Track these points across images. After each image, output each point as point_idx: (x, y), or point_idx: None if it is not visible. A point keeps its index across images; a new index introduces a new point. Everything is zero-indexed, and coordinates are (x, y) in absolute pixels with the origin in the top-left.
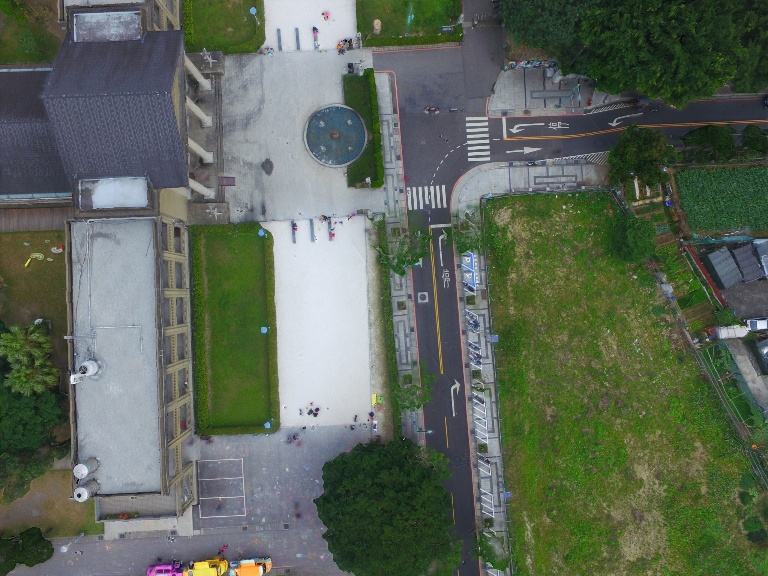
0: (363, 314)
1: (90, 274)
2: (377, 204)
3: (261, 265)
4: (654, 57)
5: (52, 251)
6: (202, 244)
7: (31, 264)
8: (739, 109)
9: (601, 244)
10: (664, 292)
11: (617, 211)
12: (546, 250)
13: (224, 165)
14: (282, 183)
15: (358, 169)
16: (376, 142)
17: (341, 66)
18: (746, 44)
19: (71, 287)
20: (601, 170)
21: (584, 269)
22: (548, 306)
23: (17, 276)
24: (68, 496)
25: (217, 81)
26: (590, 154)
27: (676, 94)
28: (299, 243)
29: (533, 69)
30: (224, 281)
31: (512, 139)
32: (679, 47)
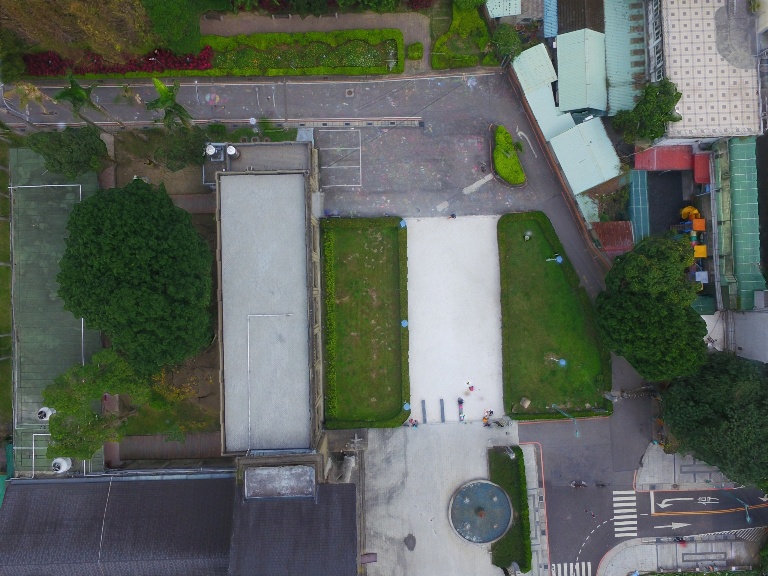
0: None
1: None
2: None
3: None
4: None
5: None
6: None
7: None
8: None
9: None
10: None
11: None
12: None
13: (366, 540)
14: (425, 559)
15: (504, 551)
16: (525, 529)
17: (486, 438)
18: None
19: None
20: (751, 546)
21: None
22: None
23: None
24: None
25: (361, 456)
26: (740, 530)
27: None
28: None
29: None
30: None
31: (660, 514)
32: None
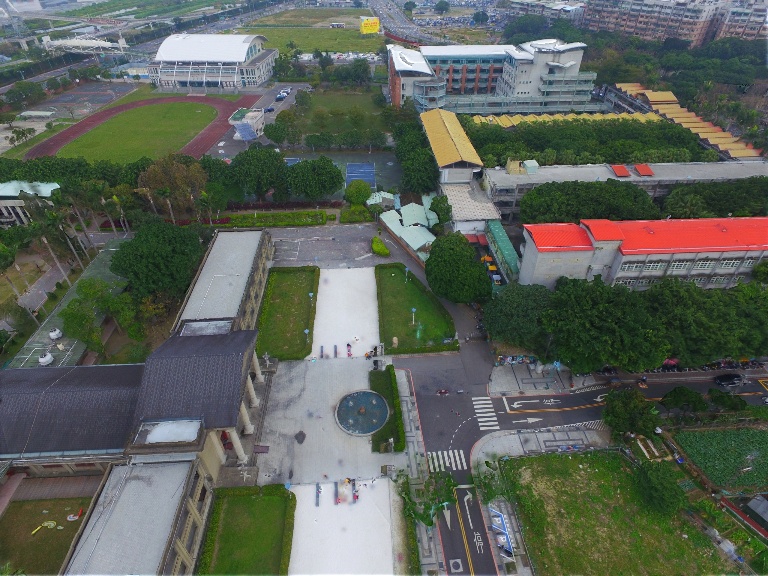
0: None
1: (109, 516)
2: (400, 467)
3: (279, 530)
4: (602, 335)
5: (67, 519)
6: (223, 509)
7: (38, 533)
8: (699, 388)
9: (632, 501)
10: (727, 554)
11: (634, 469)
12: (577, 508)
13: (261, 436)
14: (311, 450)
15: (382, 435)
16: (397, 413)
17: (368, 366)
18: (667, 330)
19: (83, 530)
20: (603, 435)
21: (625, 528)
22: (602, 574)
23: (15, 547)
24: None
25: (269, 377)
26: (587, 422)
27: (633, 361)
28: (322, 506)
29: (518, 365)
30: (236, 549)
31: (515, 412)
32: (616, 325)
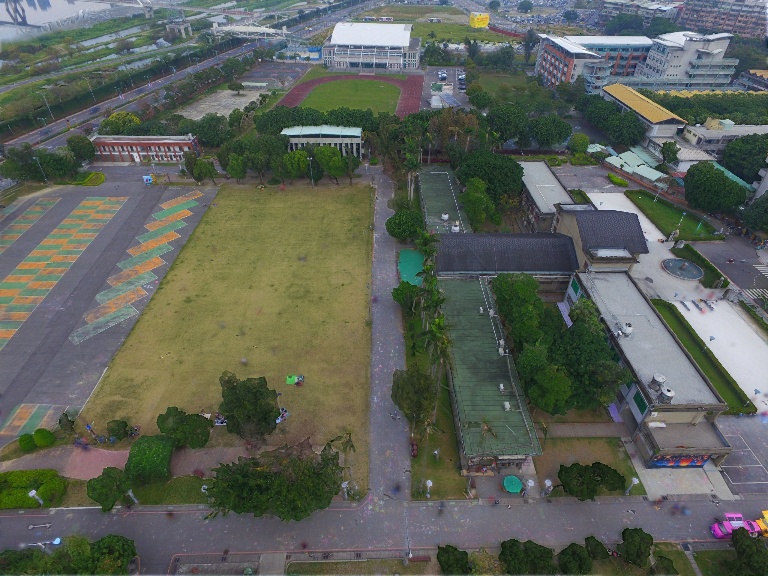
0: (765, 347)
1: (599, 293)
2: None
3: (674, 321)
4: None
5: None
6: None
7: None
8: None
9: None
10: None
11: None
12: None
13: None
14: (663, 286)
15: (708, 279)
16: (712, 267)
17: (665, 247)
18: None
19: None
20: None
21: None
22: None
23: None
24: (599, 459)
25: None
26: None
27: None
28: (692, 311)
29: None
30: None
31: None
32: None
